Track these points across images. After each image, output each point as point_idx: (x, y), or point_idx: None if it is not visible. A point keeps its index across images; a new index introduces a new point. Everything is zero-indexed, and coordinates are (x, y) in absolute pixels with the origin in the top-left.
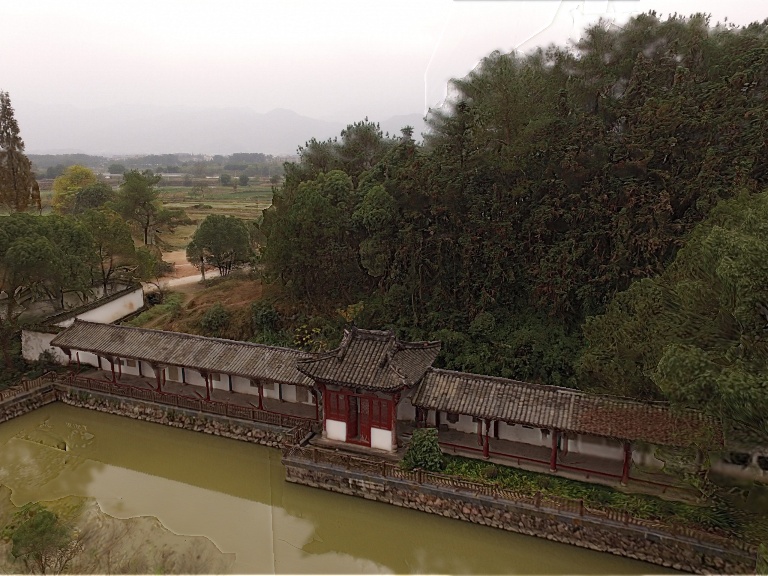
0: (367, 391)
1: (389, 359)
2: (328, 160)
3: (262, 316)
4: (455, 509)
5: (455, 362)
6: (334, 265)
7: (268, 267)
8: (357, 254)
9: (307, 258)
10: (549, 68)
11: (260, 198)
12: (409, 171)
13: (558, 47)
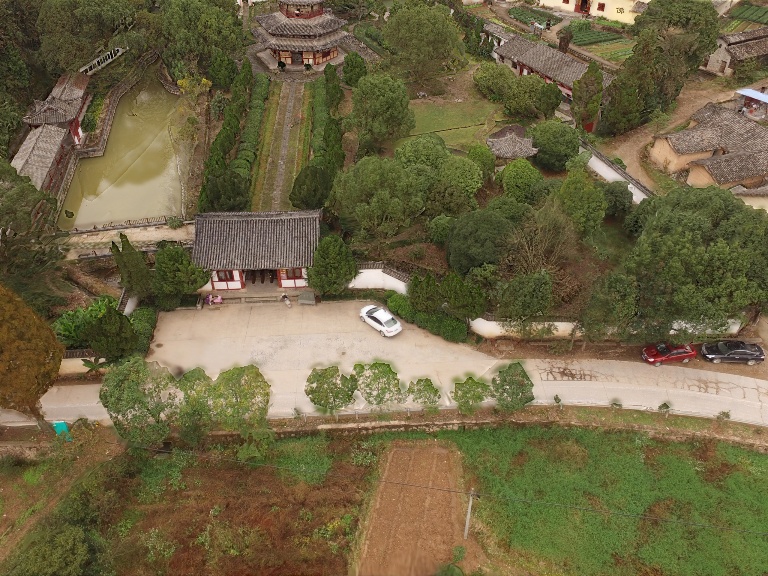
0: None
1: None
2: None
3: None
4: None
5: None
6: None
7: None
8: None
9: None
10: None
11: None
12: None
13: None
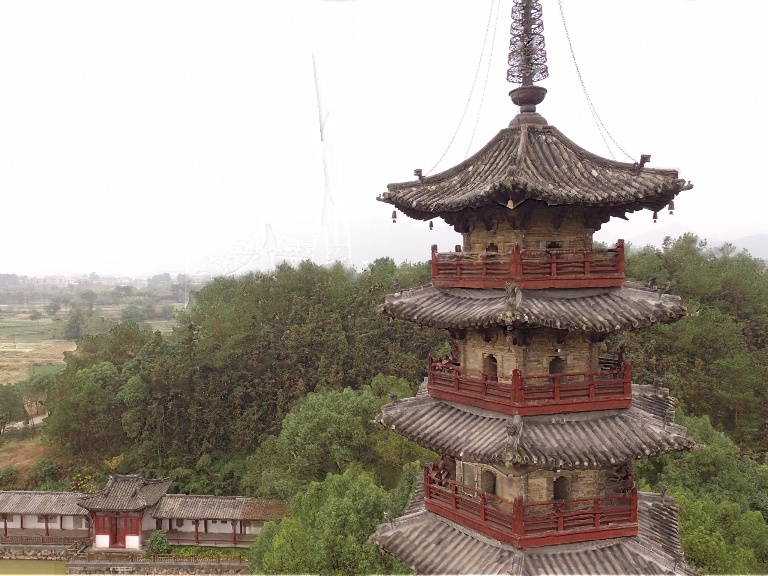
0: (123, 513)
1: (138, 491)
2: (99, 349)
3: (45, 471)
4: (174, 574)
5: (185, 489)
6: (103, 430)
7: (51, 434)
8: (120, 420)
9: (82, 426)
10: (258, 285)
11: (18, 336)
12: (155, 369)
13: (263, 272)
